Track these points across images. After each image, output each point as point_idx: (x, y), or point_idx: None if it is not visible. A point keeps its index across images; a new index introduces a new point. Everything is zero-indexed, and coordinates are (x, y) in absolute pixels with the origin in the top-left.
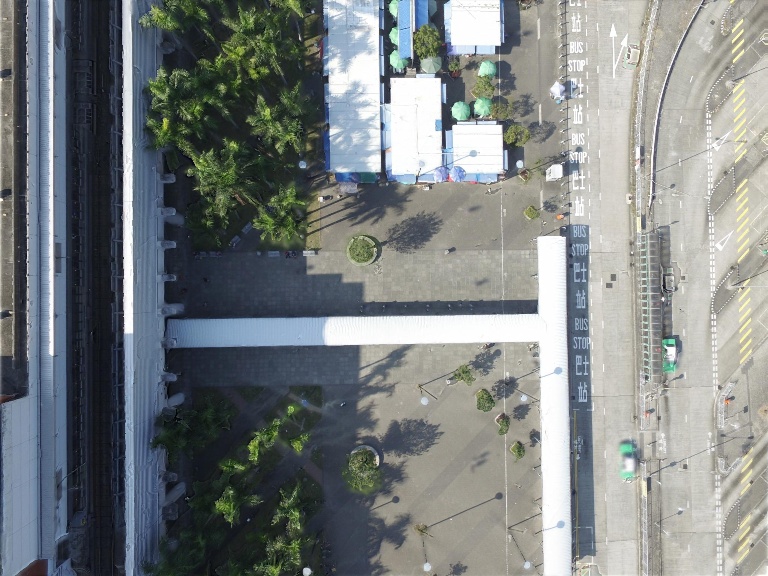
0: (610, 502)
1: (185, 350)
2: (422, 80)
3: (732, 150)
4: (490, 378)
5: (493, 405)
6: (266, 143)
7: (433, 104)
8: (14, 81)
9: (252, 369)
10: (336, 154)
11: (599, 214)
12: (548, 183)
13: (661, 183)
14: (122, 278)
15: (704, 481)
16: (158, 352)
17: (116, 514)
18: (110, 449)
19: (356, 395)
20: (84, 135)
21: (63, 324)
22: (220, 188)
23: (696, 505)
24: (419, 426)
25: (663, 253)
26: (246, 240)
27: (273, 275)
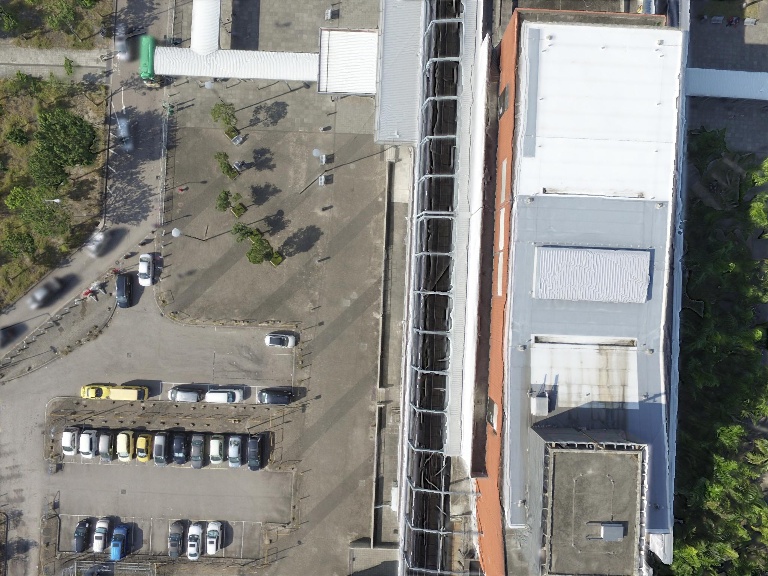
0: None
1: None
2: None
3: None
4: None
5: None
6: None
7: None
8: None
9: None
10: None
11: None
12: None
13: None
14: None
15: None
16: None
17: None
18: None
19: None
20: None
21: None
22: None
23: None
24: None
25: None
26: None
27: (713, 42)
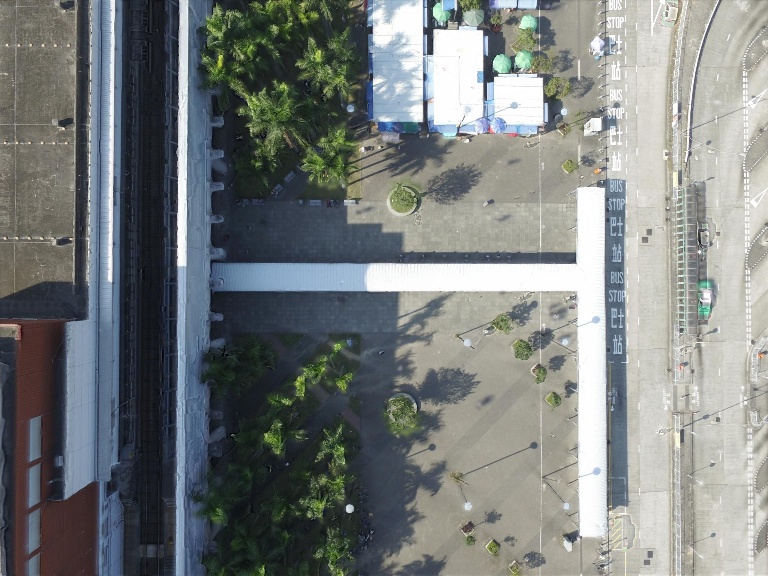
0: (643, 453)
1: (227, 296)
2: (465, 32)
3: (767, 108)
4: (526, 329)
5: (531, 353)
6: (314, 88)
7: (475, 56)
8: (77, 12)
9: (292, 316)
10: (379, 103)
11: (636, 169)
12: (586, 138)
13: (697, 140)
14: (174, 214)
15: (736, 434)
16: (200, 298)
17: (164, 448)
18: (158, 385)
19: (394, 343)
20: (140, 72)
21: (117, 257)
22: (271, 128)
23: (728, 458)
24: (456, 375)
25: (698, 209)
26: (288, 189)
27: (314, 224)
